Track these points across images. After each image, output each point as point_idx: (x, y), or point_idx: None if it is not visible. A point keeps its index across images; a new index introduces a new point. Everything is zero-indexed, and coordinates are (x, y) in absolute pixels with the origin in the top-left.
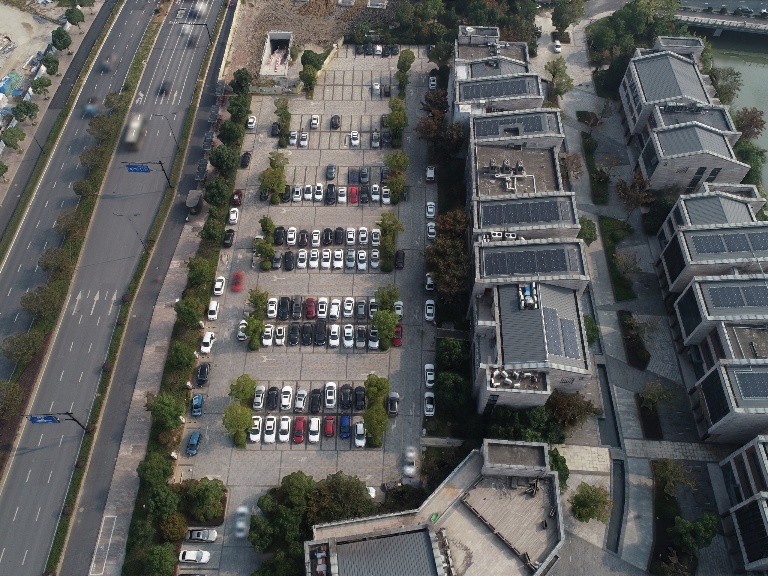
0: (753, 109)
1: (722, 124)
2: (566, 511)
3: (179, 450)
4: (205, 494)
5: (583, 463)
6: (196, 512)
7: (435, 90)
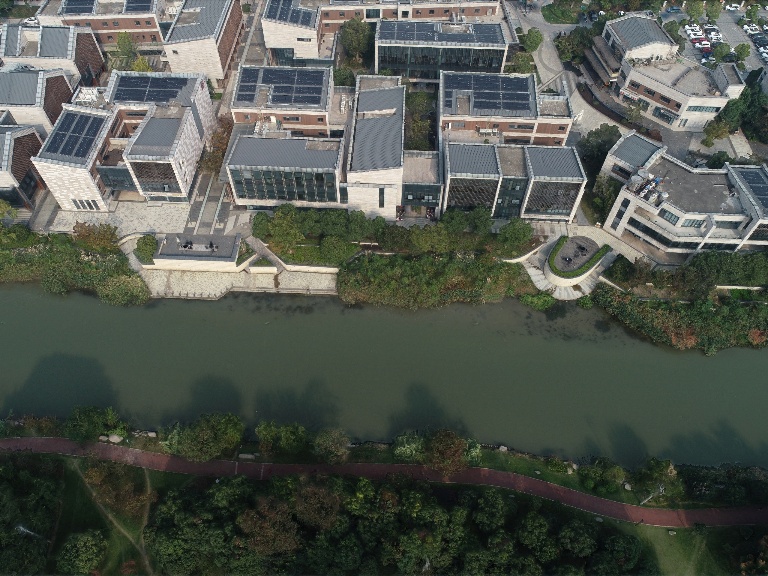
0: None
1: None
2: (704, 137)
3: (668, 7)
4: (654, 3)
5: (739, 148)
6: (644, 6)
7: None
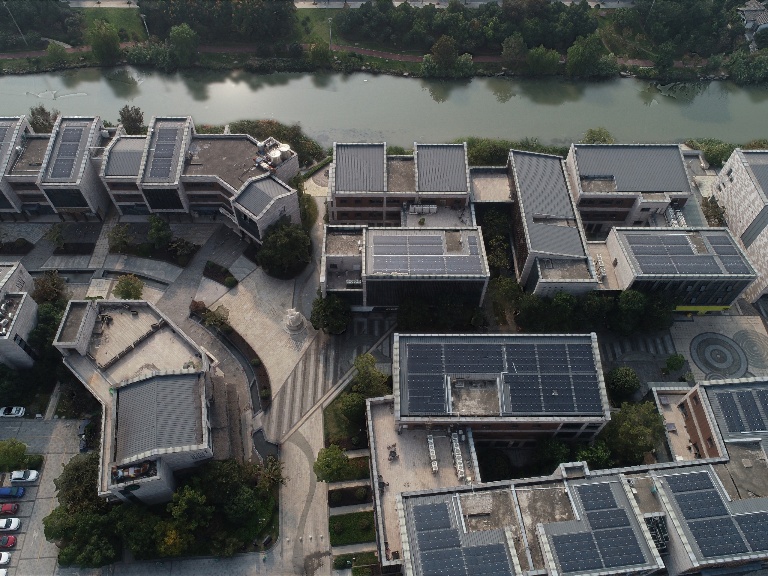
0: None
1: None
2: None
3: None
4: None
5: None
6: None
7: None
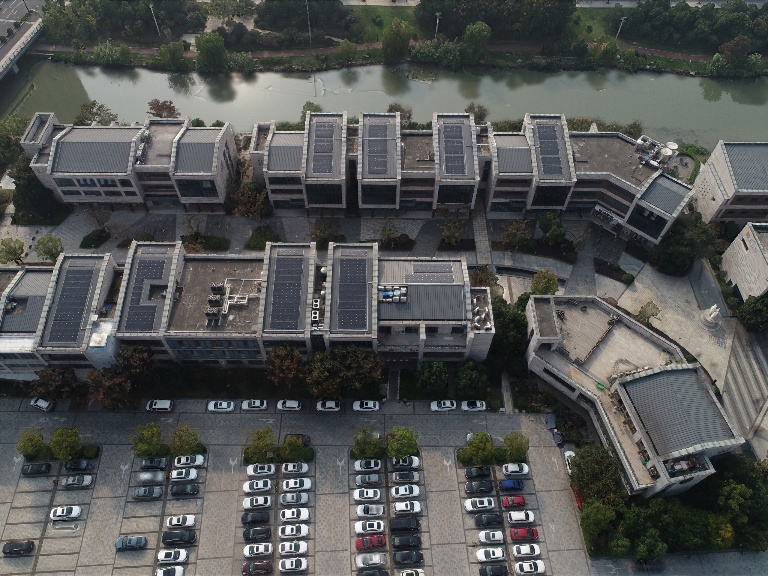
0: (151, 104)
1: (170, 126)
2: None
3: None
4: None
5: None
6: None
7: (35, 381)
